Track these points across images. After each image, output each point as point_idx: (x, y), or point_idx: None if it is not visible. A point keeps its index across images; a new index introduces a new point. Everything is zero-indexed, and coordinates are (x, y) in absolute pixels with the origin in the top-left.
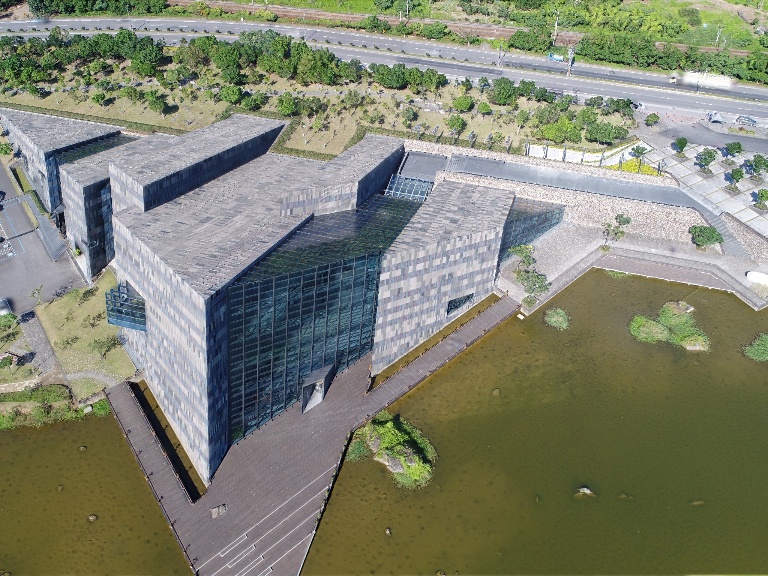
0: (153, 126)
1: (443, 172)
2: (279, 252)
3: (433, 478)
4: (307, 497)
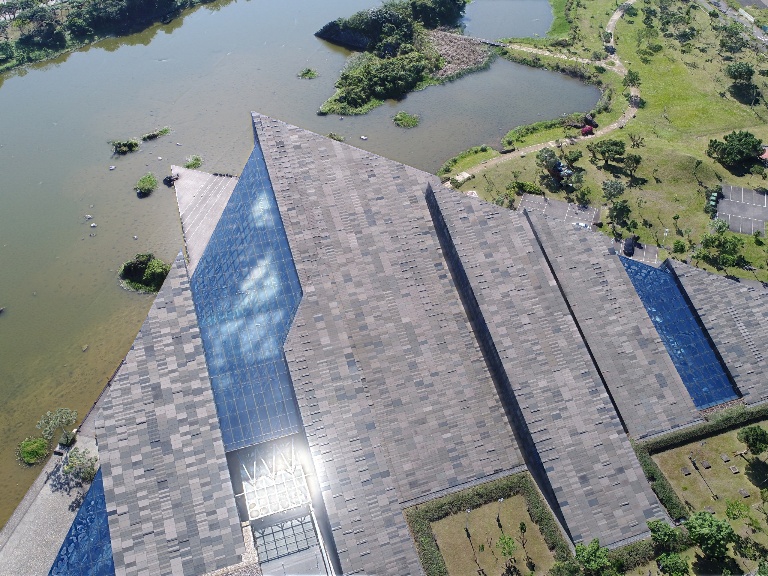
0: (717, 421)
1: (249, 568)
2: (272, 210)
3: (118, 272)
4: (196, 223)
